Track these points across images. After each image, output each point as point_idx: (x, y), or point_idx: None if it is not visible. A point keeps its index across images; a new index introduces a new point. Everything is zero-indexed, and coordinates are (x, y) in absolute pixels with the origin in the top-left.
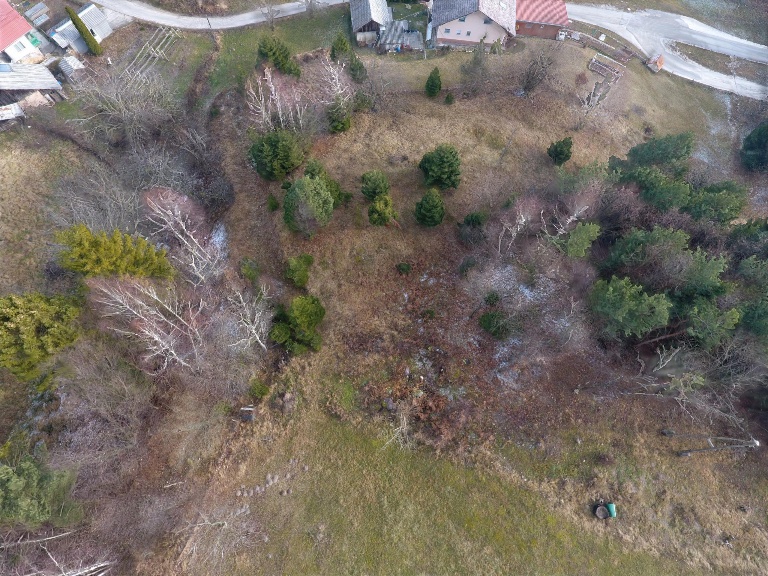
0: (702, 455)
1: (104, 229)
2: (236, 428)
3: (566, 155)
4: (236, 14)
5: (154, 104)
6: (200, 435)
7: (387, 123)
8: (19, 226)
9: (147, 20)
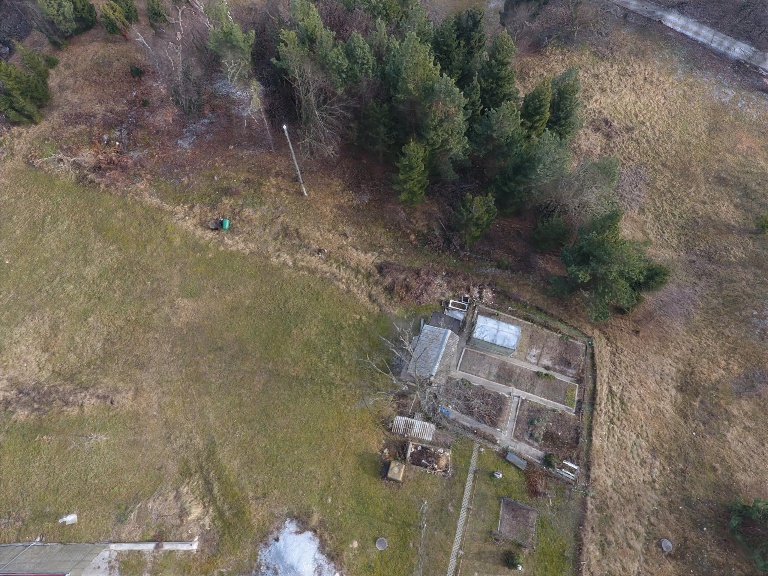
0: (326, 197)
1: None
2: None
3: None
4: None
5: None
6: None
7: None
8: None
9: None
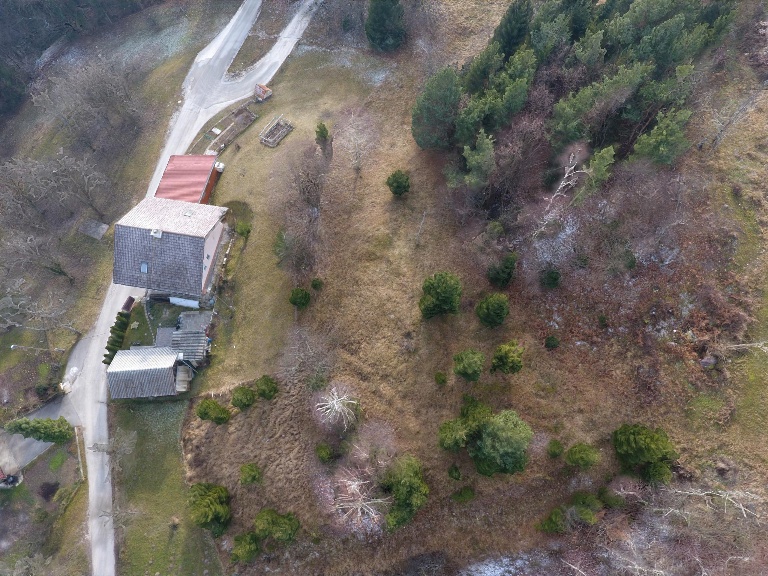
0: None
1: None
2: (763, 523)
3: None
4: (90, 574)
5: None
6: None
7: (345, 355)
8: None
9: None
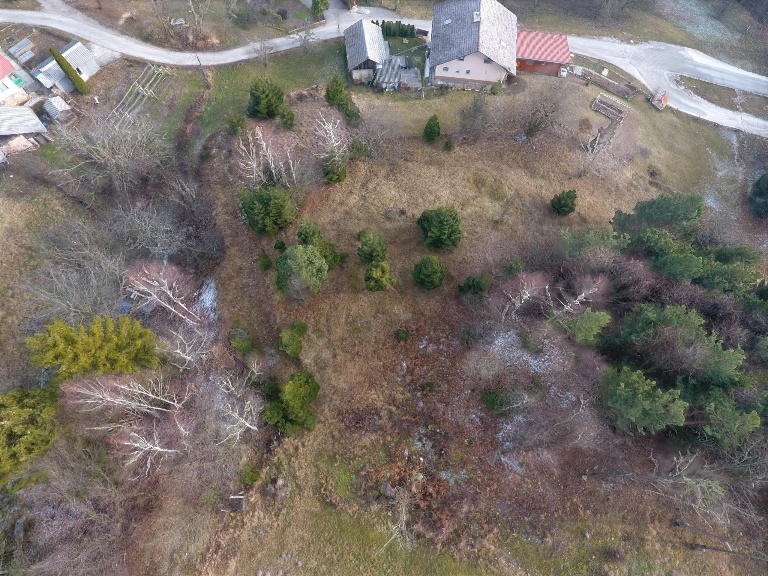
0: (717, 547)
1: (87, 295)
2: (225, 518)
3: (570, 207)
4: (228, 49)
5: (142, 149)
6: (187, 526)
7: (384, 172)
8: (1, 282)
9: (136, 56)
